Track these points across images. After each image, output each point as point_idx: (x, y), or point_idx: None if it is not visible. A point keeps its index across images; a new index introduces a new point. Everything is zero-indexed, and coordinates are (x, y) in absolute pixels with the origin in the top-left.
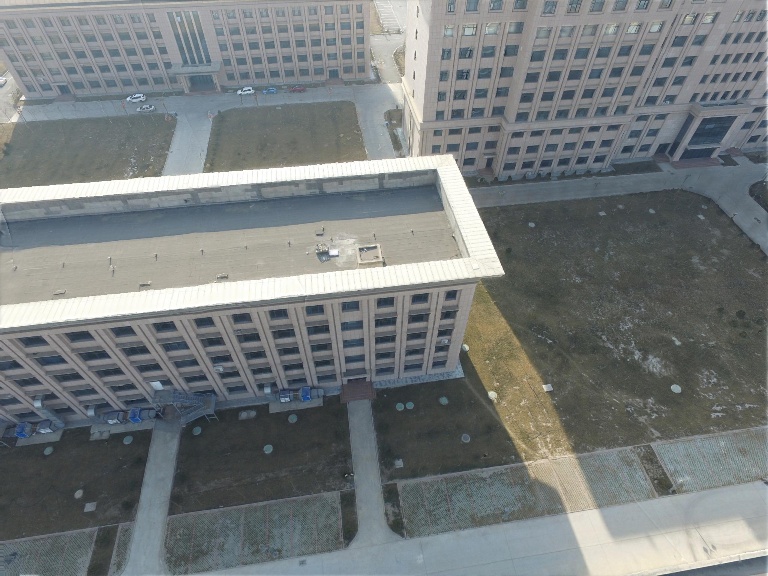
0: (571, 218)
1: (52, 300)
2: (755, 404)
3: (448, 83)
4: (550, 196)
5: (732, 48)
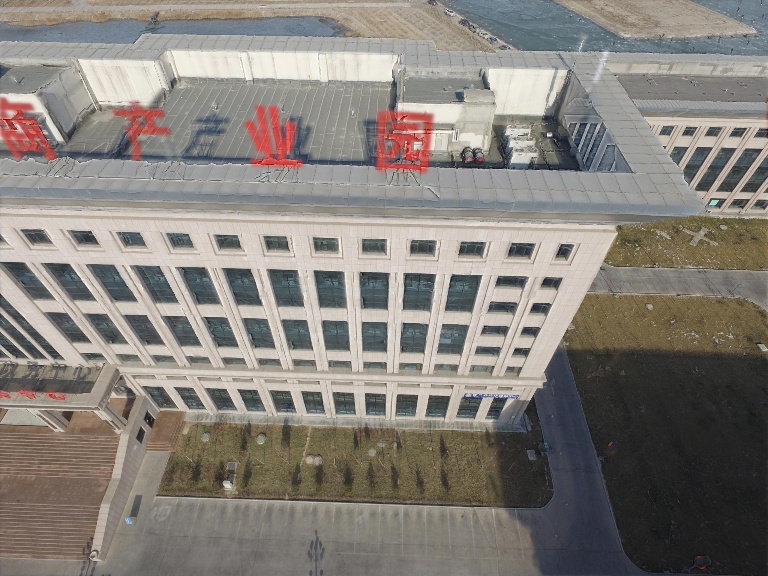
0: None
1: (733, 60)
2: None
3: None
4: None
5: None
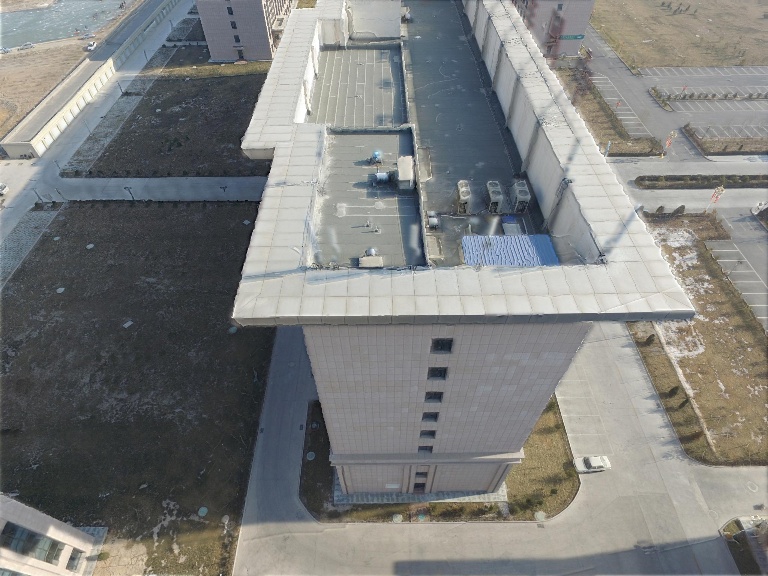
0: None
1: None
2: None
3: None
4: None
5: None
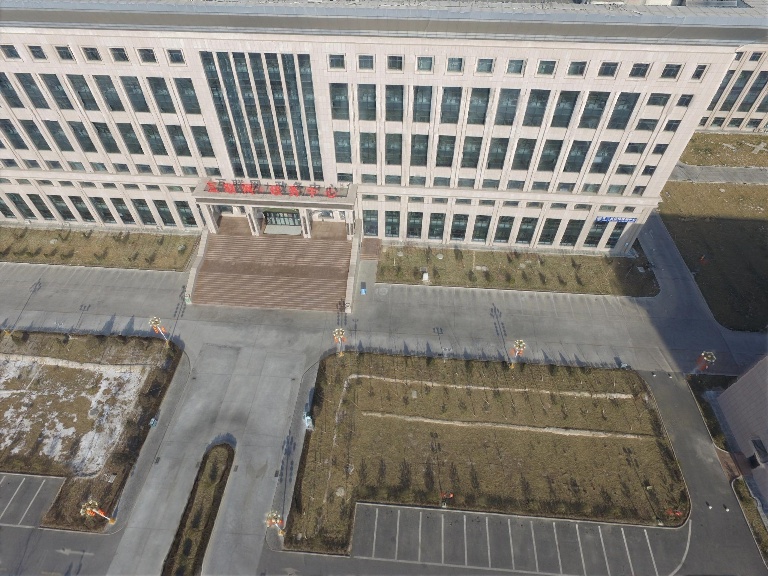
0: None
1: None
2: None
3: None
4: None
5: None
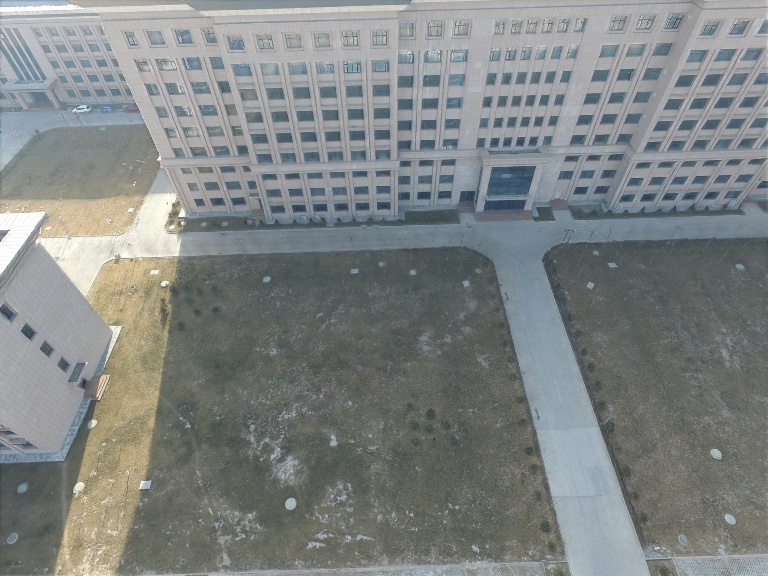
0: (316, 274)
1: None
2: (370, 536)
3: (170, 120)
4: (312, 246)
5: (504, 89)
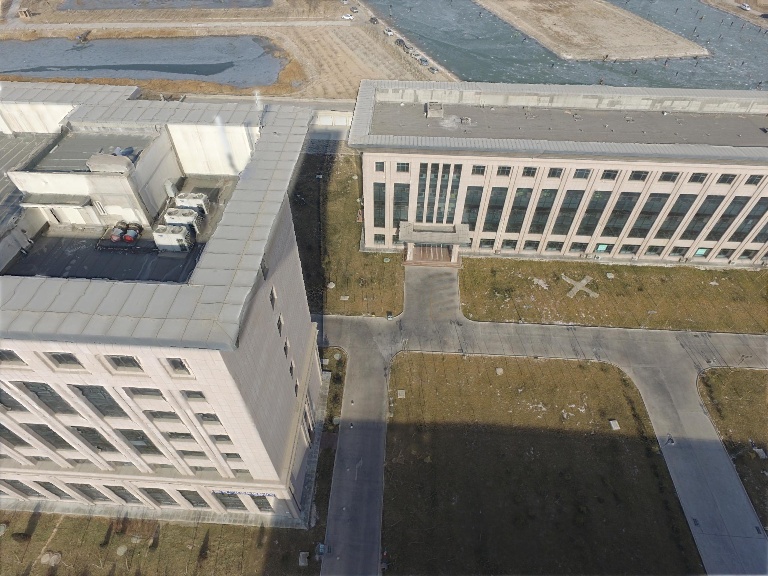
0: None
1: (618, 93)
2: None
3: None
4: None
5: None
